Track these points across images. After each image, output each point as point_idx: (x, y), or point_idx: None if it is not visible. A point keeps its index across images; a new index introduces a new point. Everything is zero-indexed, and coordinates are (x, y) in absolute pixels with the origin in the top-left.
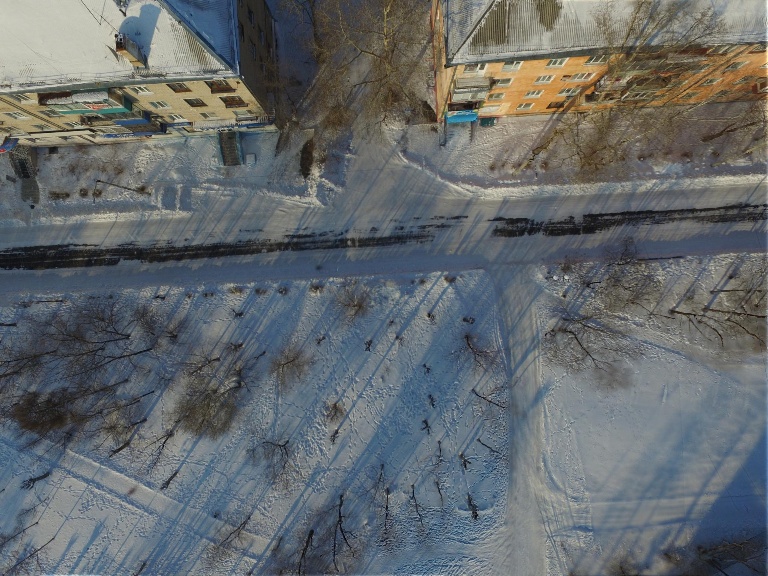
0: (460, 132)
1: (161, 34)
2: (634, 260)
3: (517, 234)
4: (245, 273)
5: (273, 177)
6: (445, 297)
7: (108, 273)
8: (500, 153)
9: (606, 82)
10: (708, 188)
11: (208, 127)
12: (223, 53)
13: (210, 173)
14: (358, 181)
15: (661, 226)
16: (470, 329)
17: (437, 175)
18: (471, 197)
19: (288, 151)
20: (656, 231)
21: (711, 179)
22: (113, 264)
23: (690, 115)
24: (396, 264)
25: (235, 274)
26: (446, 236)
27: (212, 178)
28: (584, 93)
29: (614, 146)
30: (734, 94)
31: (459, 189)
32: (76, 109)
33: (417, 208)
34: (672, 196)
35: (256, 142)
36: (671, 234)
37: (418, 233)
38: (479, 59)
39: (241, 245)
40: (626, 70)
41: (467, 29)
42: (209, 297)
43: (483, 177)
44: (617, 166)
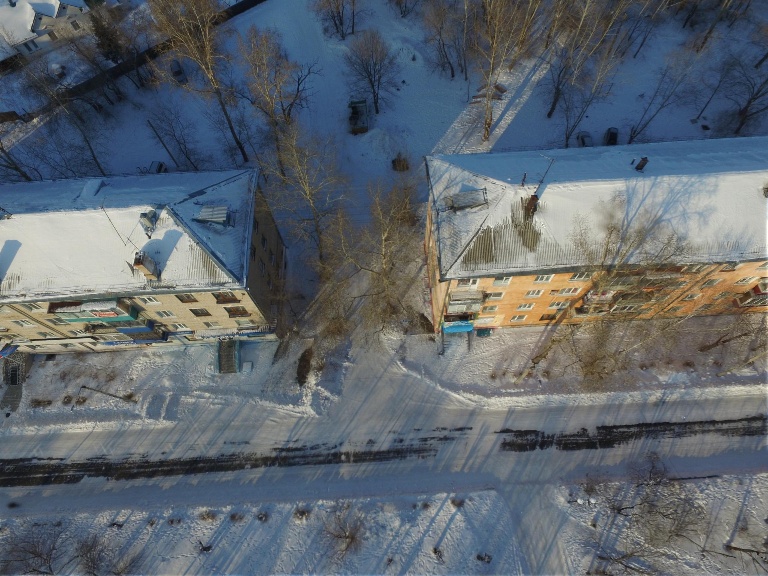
0: (458, 342)
1: (179, 253)
2: (665, 480)
3: (528, 448)
4: (222, 494)
5: (268, 385)
6: (453, 526)
7: (66, 493)
8: (499, 362)
9: (593, 296)
10: (721, 398)
11: (209, 335)
12: (233, 269)
13: (203, 381)
14: (355, 389)
15: (684, 440)
16: (486, 571)
17: (437, 384)
18: (474, 407)
19: (286, 359)
20: (680, 445)
21: (721, 389)
22: (75, 482)
23: (680, 327)
24: (395, 483)
25: (211, 495)
26: (450, 450)
27: (205, 386)
28: (573, 306)
29: (613, 356)
30: (717, 308)
31: (461, 398)
32: (83, 317)
33: (417, 418)
34: (686, 407)
35: (255, 350)
36: (697, 449)
37: (419, 446)
38: (471, 274)
39: (223, 460)
40: (610, 285)
41: (458, 250)
42: (175, 525)
43: (484, 386)
44: (621, 375)
